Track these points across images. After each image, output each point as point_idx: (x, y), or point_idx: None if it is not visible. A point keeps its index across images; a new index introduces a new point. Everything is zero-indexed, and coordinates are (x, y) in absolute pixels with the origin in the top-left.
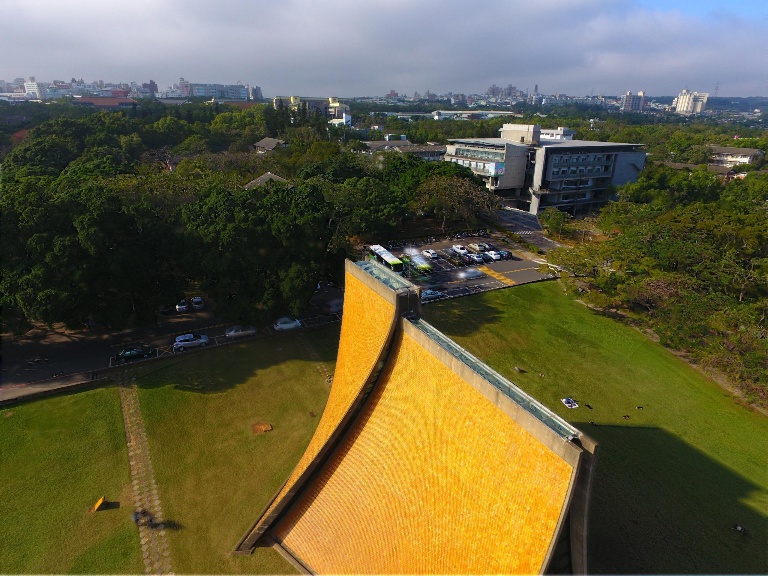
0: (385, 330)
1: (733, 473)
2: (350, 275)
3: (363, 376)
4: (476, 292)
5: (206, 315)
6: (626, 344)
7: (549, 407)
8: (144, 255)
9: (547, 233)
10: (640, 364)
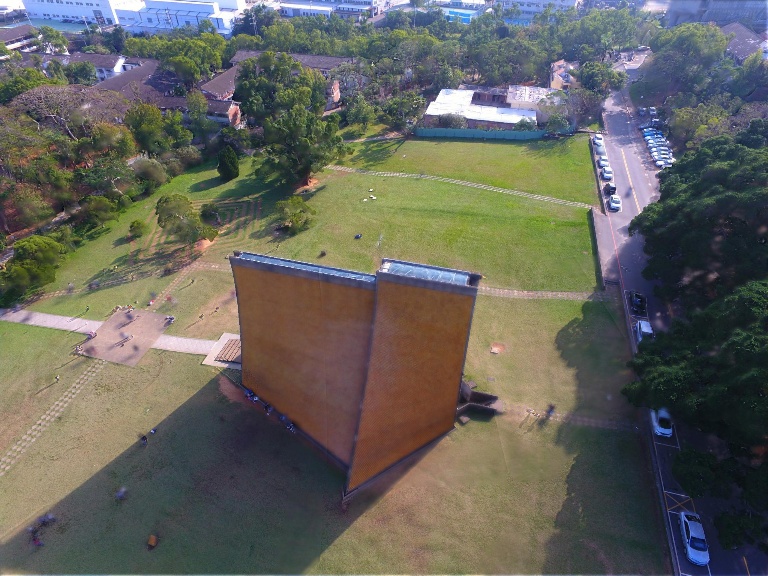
0: None
1: None
2: None
3: None
4: None
5: None
6: None
7: (346, 572)
8: (727, 258)
9: None
10: None
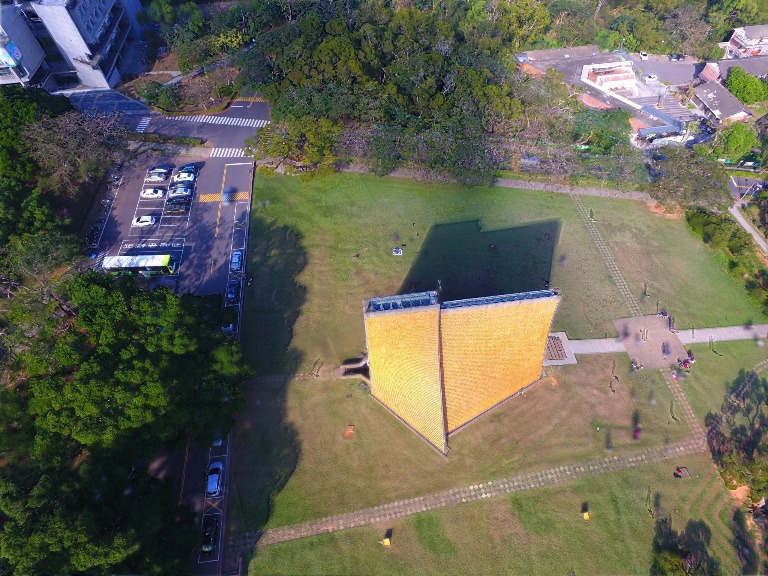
0: (434, 323)
1: (465, 224)
2: (374, 318)
3: (434, 348)
4: (247, 227)
5: (157, 464)
6: (358, 188)
7: (397, 264)
8: None
9: (163, 111)
10: (380, 196)
